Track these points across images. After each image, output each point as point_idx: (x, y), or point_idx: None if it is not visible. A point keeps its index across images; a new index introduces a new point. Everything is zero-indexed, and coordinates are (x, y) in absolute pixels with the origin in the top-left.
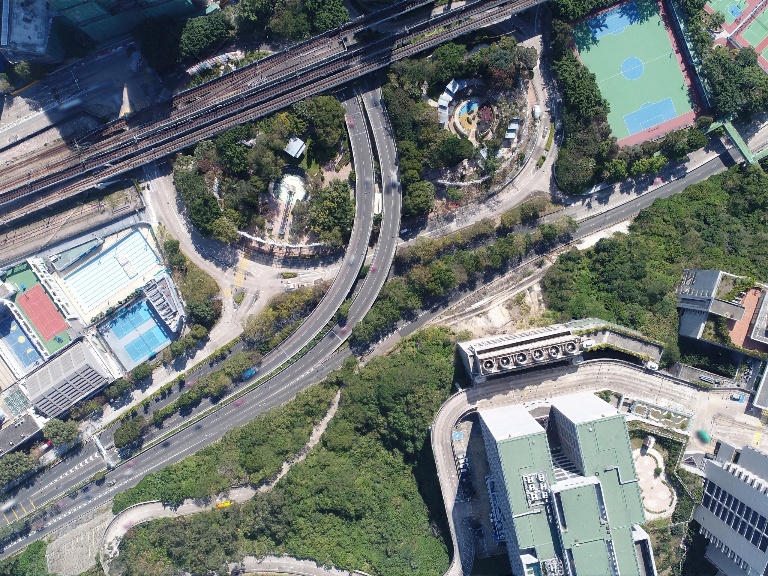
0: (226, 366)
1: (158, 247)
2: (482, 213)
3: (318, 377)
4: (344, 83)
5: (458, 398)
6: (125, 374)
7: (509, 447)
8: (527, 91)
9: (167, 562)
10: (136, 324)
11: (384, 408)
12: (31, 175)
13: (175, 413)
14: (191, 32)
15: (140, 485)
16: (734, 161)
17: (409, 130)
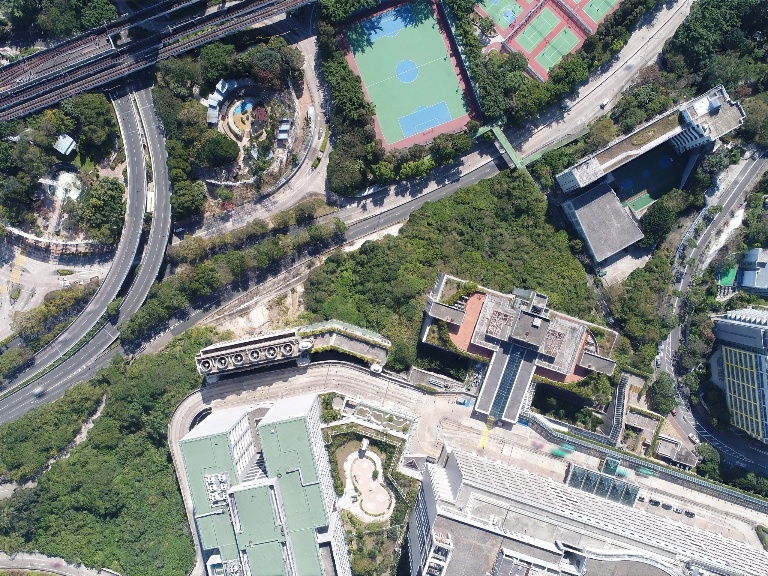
0: None
1: None
2: (258, 213)
3: (90, 375)
4: (115, 81)
5: (193, 398)
6: None
7: (191, 447)
8: (302, 92)
9: None
10: None
11: (147, 407)
12: None
13: None
14: None
15: None
16: (508, 165)
17: (174, 129)
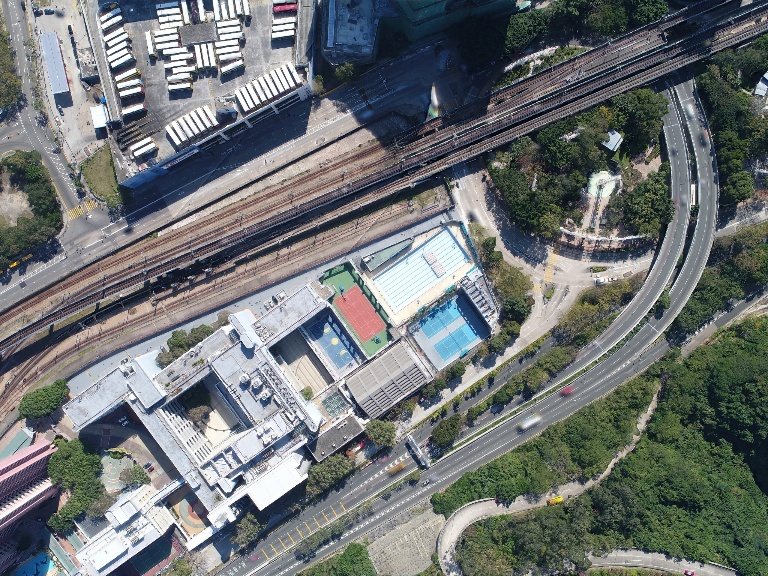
0: (544, 362)
1: (468, 245)
2: None
3: (634, 370)
4: None
5: None
6: (435, 373)
7: None
8: None
9: (512, 559)
10: (446, 323)
11: (714, 398)
12: (345, 176)
13: (486, 411)
14: (516, 29)
15: (462, 484)
16: None
17: (732, 120)
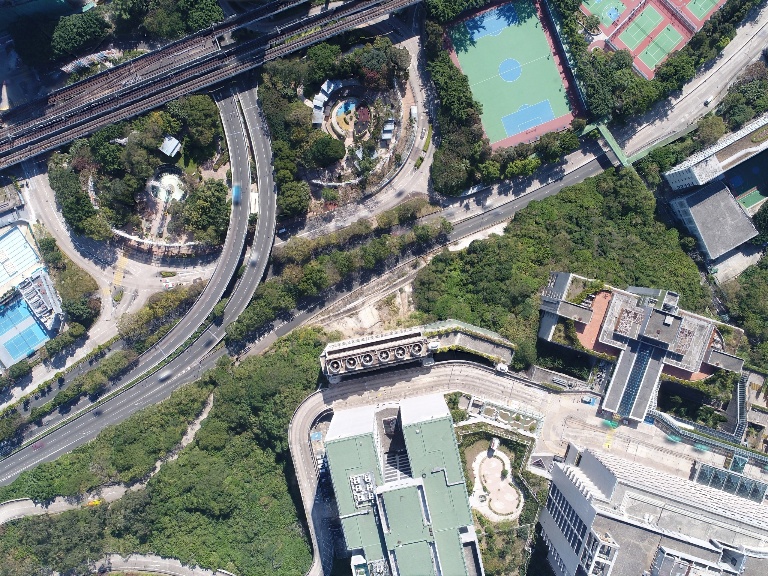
0: (102, 364)
1: (37, 245)
2: (360, 214)
3: (195, 376)
4: (220, 82)
5: (314, 398)
6: (4, 371)
7: (336, 448)
8: (405, 92)
9: (34, 559)
10: (15, 321)
11: (255, 408)
12: None
13: (54, 411)
14: (63, 30)
15: (15, 482)
16: (611, 164)
17: (282, 130)
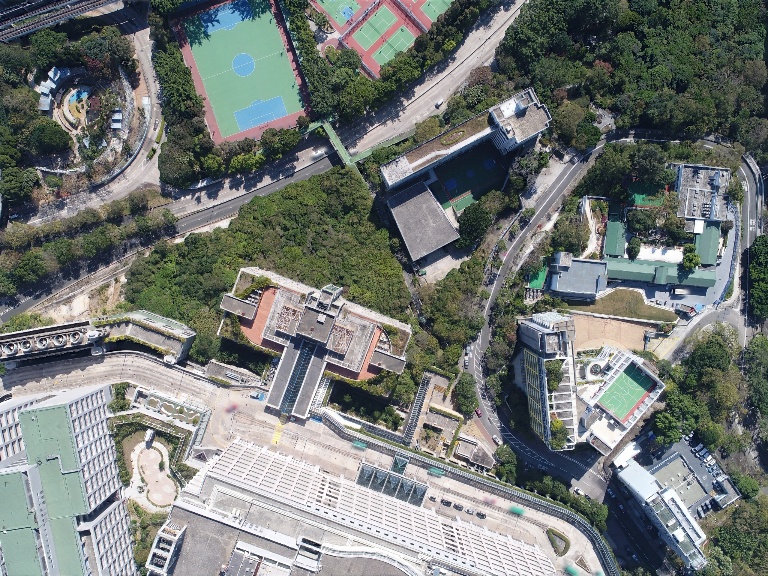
0: None
1: None
2: (93, 202)
3: None
4: None
5: None
6: None
7: None
8: (139, 82)
9: None
10: None
11: None
12: None
13: None
14: None
15: None
16: (342, 162)
17: (3, 115)
